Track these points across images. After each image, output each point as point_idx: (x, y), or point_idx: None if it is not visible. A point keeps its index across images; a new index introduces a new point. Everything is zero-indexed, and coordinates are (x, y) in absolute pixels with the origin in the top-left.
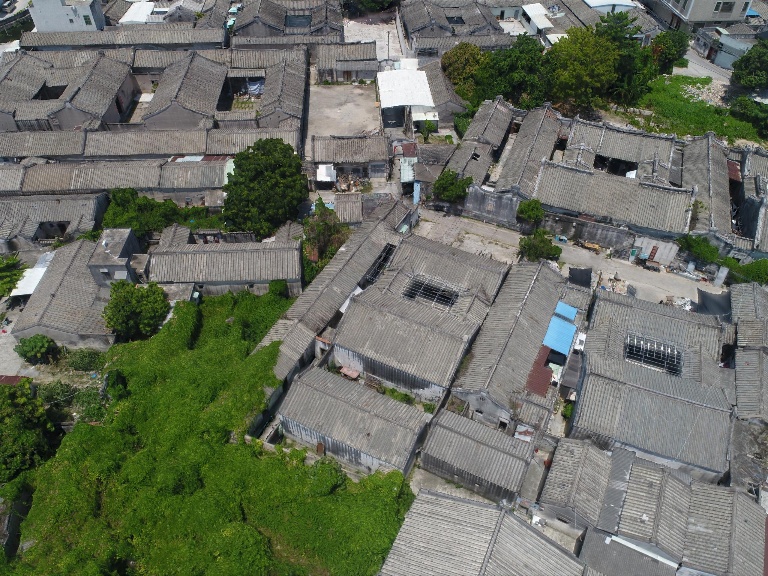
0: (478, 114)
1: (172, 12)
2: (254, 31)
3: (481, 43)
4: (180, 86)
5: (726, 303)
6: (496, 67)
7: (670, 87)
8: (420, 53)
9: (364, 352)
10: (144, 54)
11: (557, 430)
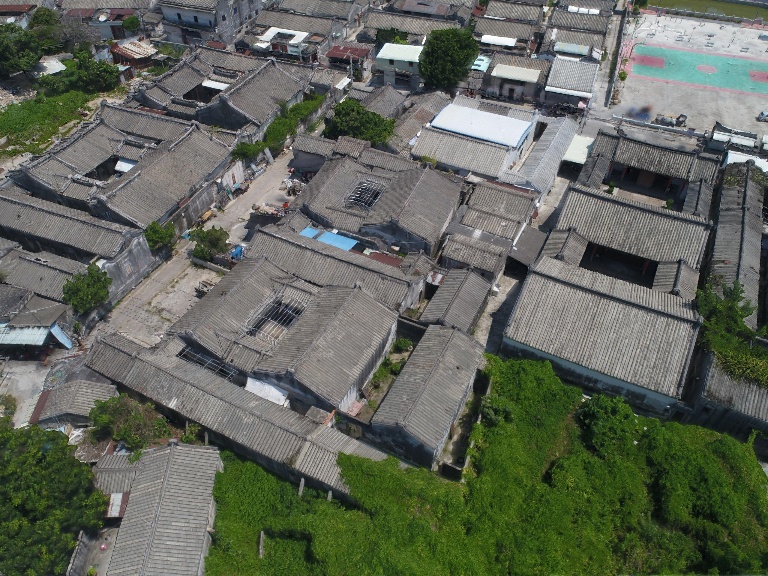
0: None
1: None
2: None
3: None
4: None
5: (308, 156)
6: None
7: None
8: None
9: (354, 375)
10: None
11: None
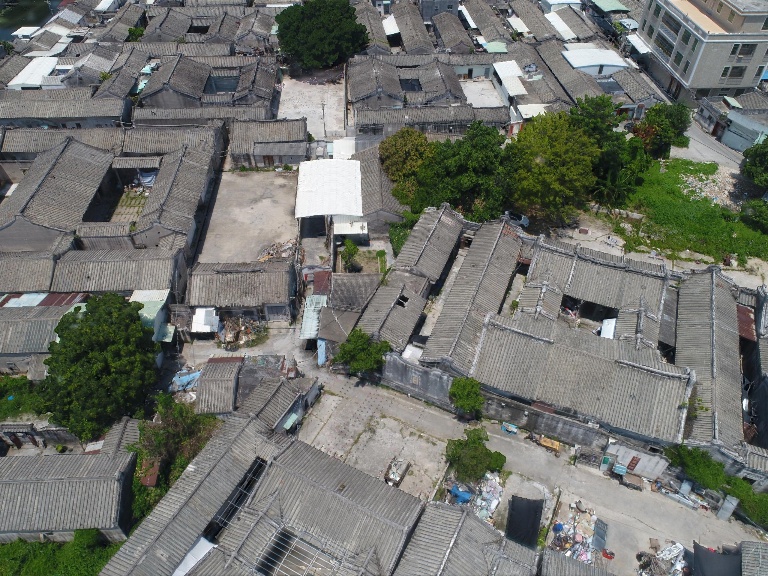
0: (417, 227)
1: (71, 73)
2: (164, 99)
3: (436, 117)
4: (35, 191)
5: (735, 575)
6: (442, 165)
7: (666, 177)
8: (362, 129)
9: None
10: (16, 135)
11: None
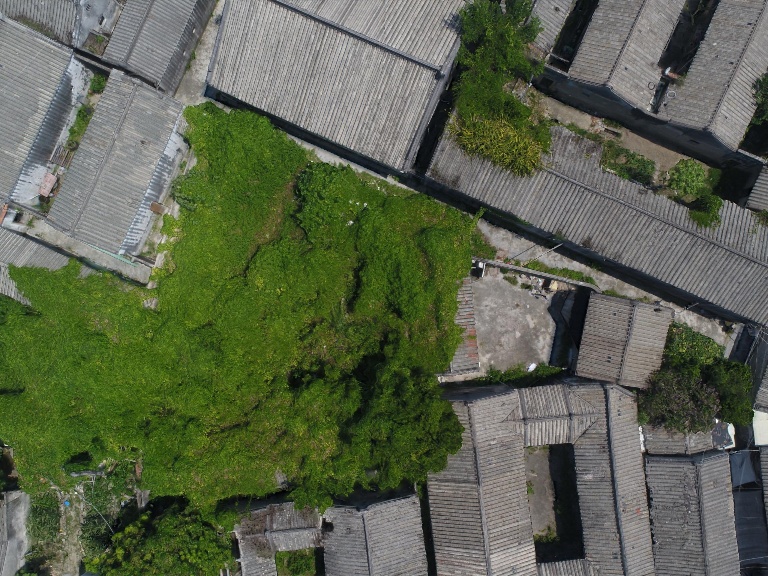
0: None
1: None
2: None
3: None
4: None
5: None
6: None
7: None
8: None
9: (21, 157)
10: None
11: None
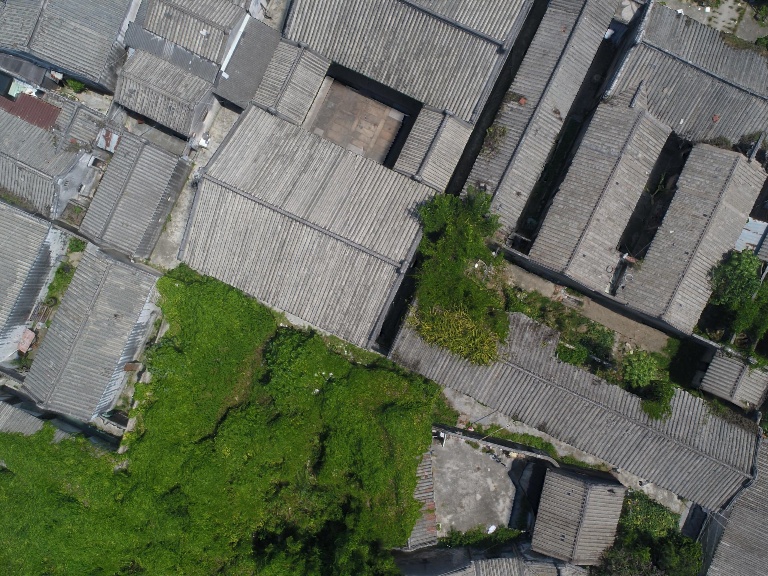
0: None
1: None
2: None
3: None
4: None
5: None
6: None
7: None
8: None
9: None
10: None
11: (100, 102)
